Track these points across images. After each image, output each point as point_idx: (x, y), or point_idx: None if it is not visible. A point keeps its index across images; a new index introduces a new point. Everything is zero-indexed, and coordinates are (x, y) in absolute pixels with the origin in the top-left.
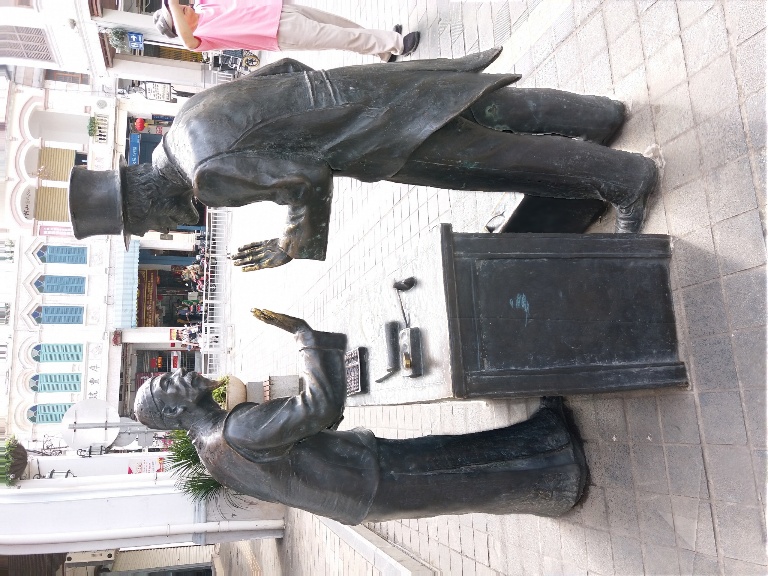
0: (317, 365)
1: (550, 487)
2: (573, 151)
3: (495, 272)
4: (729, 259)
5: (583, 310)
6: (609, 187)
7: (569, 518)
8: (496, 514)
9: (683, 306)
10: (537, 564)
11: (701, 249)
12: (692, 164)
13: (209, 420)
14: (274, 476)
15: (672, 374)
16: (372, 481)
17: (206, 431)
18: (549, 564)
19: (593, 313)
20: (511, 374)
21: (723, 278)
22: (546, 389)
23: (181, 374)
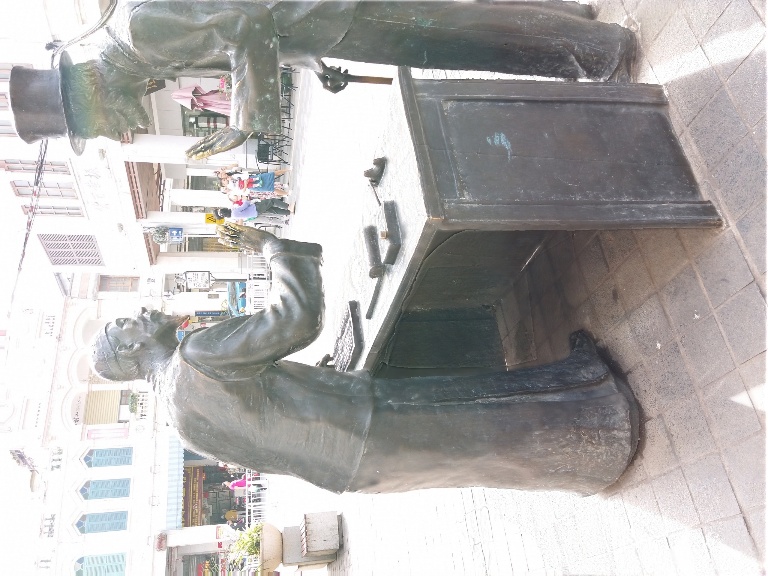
0: (287, 271)
1: (594, 424)
2: (535, 11)
3: (466, 113)
4: (727, 60)
5: (575, 150)
6: (584, 49)
7: (631, 481)
8: (536, 479)
9: (694, 144)
10: (607, 568)
11: (696, 72)
12: (665, 3)
13: (170, 355)
14: (242, 400)
15: (698, 211)
16: (364, 408)
17: (165, 364)
18: (621, 558)
19: (588, 153)
20: (498, 203)
21: (726, 83)
22: (544, 219)
23: (140, 312)
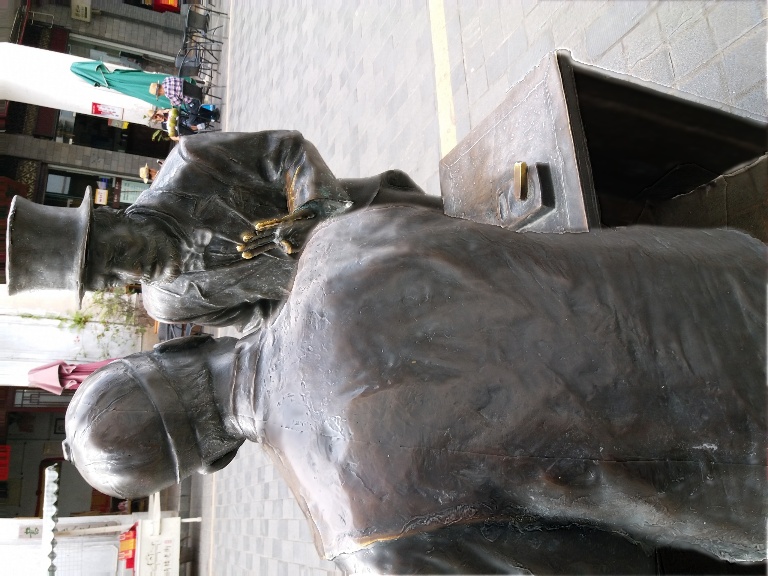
0: None
1: None
2: None
3: None
4: None
5: None
6: None
7: None
8: None
9: None
10: None
11: None
12: None
13: None
14: None
15: None
16: None
17: None
18: None
19: None
20: None
21: None
22: None
23: None
